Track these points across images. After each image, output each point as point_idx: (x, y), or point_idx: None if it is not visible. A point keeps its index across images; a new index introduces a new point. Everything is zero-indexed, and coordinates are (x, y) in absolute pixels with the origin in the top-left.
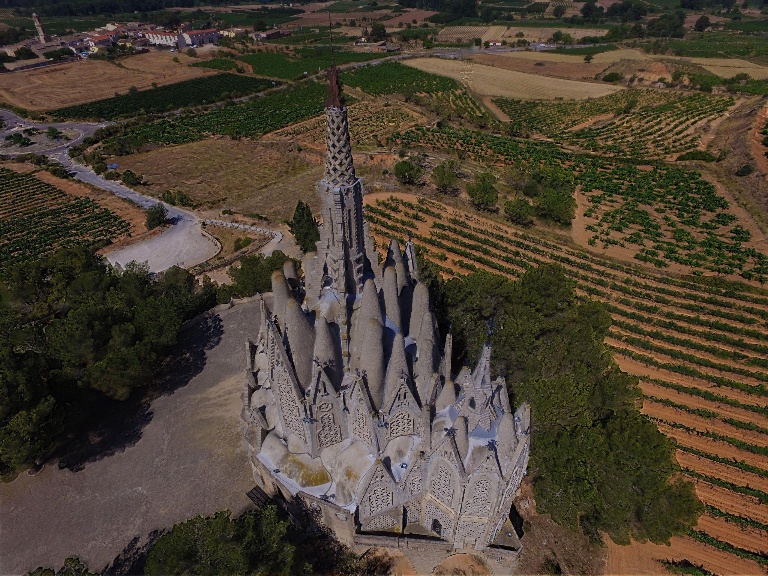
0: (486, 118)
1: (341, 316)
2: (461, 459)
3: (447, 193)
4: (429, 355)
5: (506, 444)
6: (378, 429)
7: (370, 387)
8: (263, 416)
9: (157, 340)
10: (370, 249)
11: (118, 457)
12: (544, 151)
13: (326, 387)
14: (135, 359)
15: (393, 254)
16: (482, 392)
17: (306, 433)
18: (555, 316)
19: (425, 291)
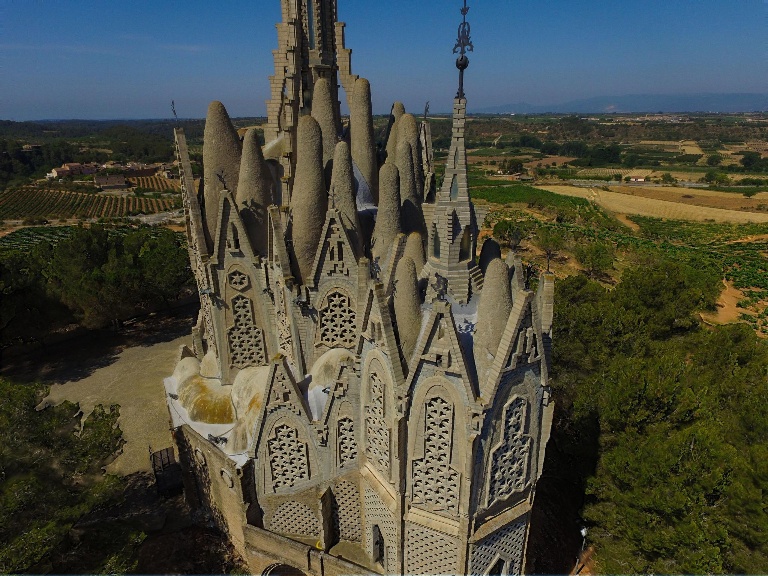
0: (615, 222)
1: (285, 147)
2: (403, 351)
3: (551, 259)
4: (390, 191)
5: (490, 326)
6: (301, 321)
7: (294, 237)
8: (203, 345)
9: (152, 277)
10: (344, 68)
11: (54, 387)
12: (684, 248)
13: (239, 239)
14: (111, 277)
15: (394, 121)
16: (449, 208)
17: (215, 332)
18: (670, 341)
19: (410, 123)
